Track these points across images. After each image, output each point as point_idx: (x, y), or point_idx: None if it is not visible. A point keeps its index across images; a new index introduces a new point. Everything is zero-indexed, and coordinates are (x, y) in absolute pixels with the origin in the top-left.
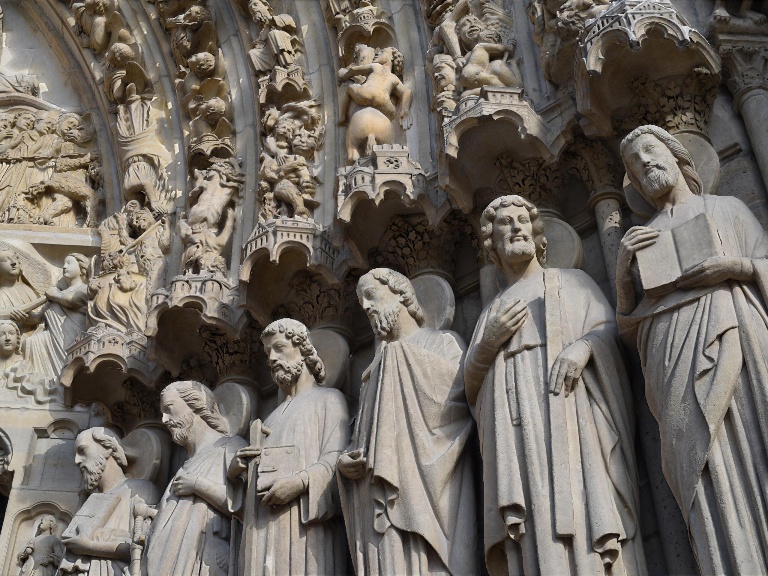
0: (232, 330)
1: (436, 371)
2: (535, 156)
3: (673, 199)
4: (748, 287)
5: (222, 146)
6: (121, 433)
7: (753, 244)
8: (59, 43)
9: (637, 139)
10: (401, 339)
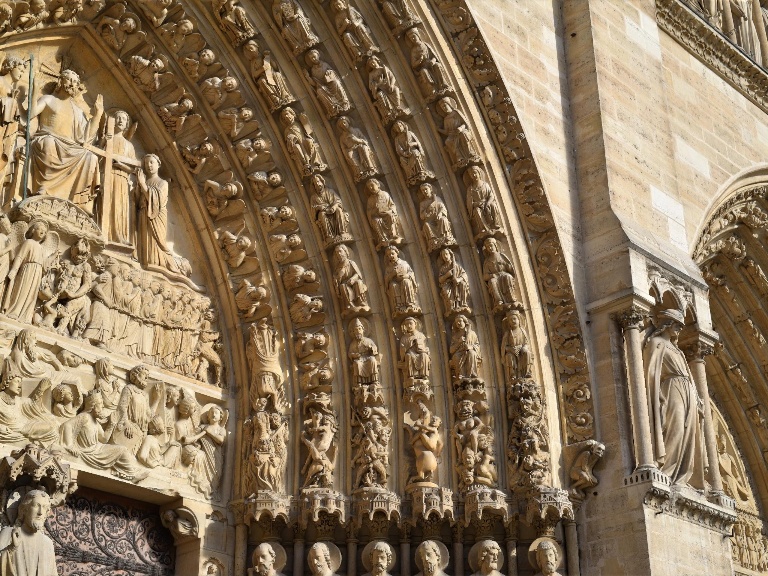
0: (344, 525)
1: None
2: (495, 514)
3: (551, 575)
4: None
5: None
6: (248, 529)
7: None
8: (197, 235)
9: (549, 550)
10: (435, 575)
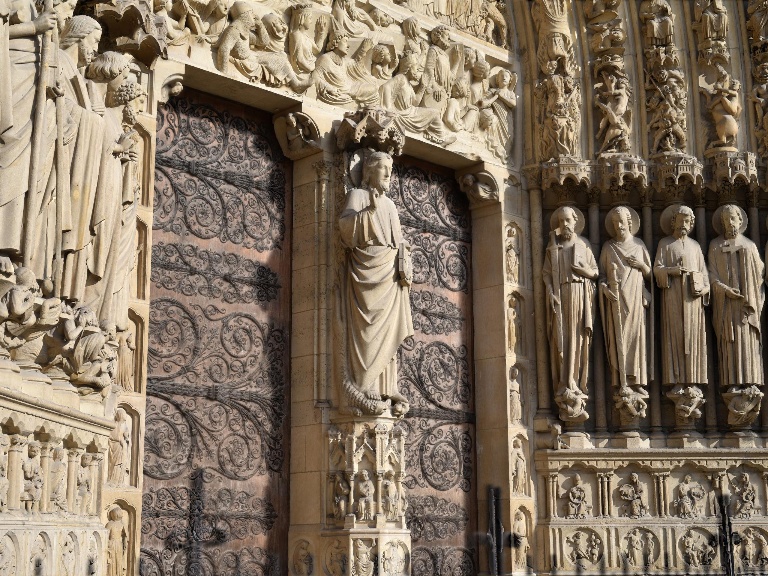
0: None
1: (760, 265)
2: None
3: None
4: None
5: (623, 65)
6: (541, 193)
7: None
8: None
9: None
10: (737, 238)
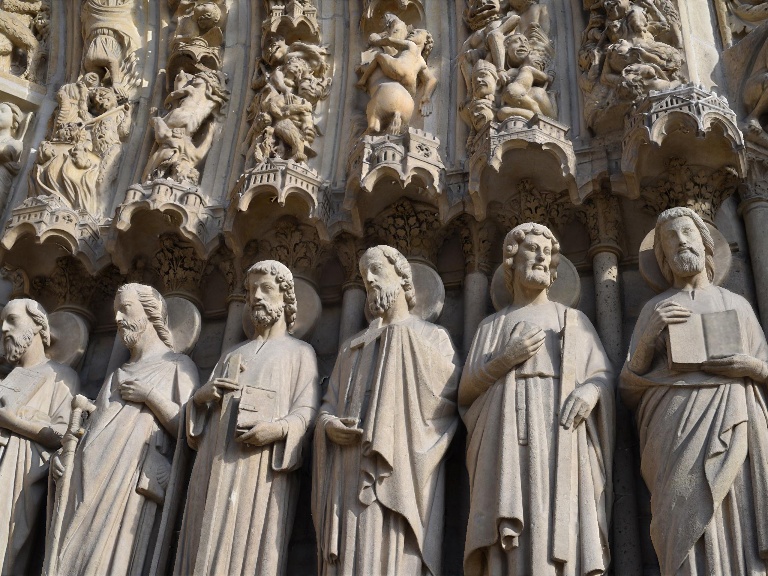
0: (202, 249)
1: (436, 365)
2: (554, 190)
3: (695, 282)
4: (759, 388)
5: (212, 55)
6: None
7: (757, 347)
8: None
9: (679, 218)
10: (394, 320)
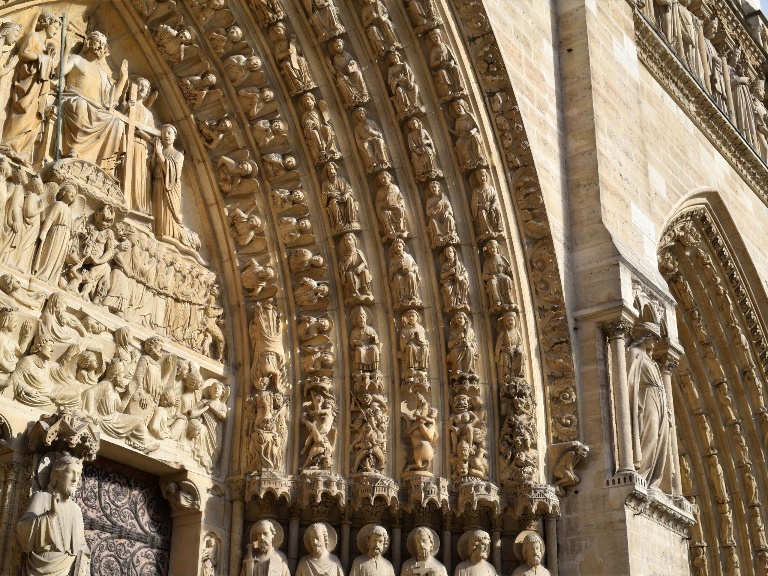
0: None
1: None
2: (485, 505)
3: (536, 566)
4: None
5: None
6: (244, 505)
7: None
8: (206, 210)
9: (536, 543)
10: (428, 561)
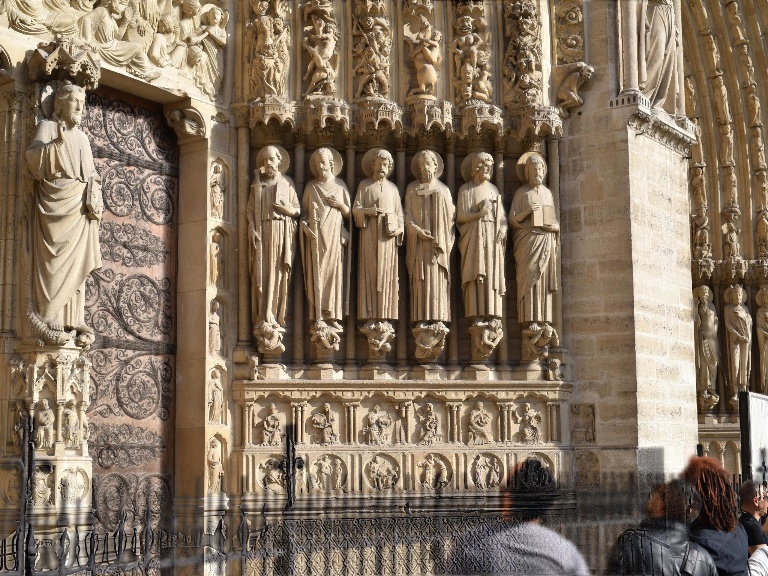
0: None
1: None
2: None
3: (538, 186)
4: (555, 233)
5: None
6: (249, 131)
7: None
8: None
9: (538, 164)
10: (432, 183)
